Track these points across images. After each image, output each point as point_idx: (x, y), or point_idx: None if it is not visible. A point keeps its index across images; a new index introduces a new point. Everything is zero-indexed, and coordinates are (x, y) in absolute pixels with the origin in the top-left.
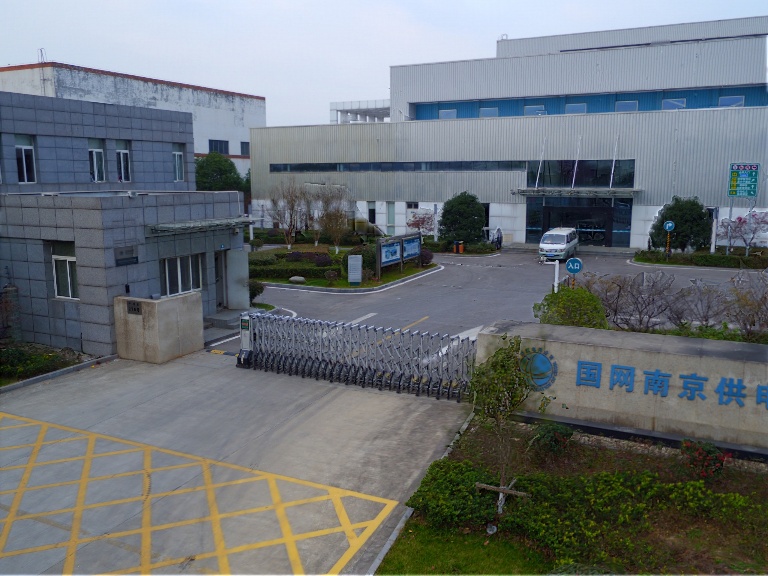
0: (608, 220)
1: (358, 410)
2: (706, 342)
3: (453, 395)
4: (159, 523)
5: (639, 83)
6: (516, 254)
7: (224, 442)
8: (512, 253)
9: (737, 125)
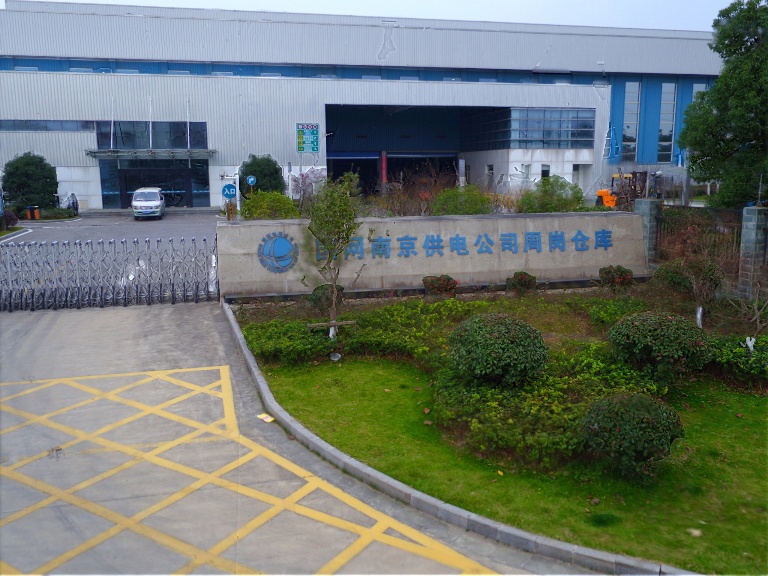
0: (187, 181)
1: (97, 323)
2: (399, 217)
3: (186, 298)
4: None
5: (190, 53)
6: (100, 218)
7: None
8: (95, 217)
9: (290, 93)
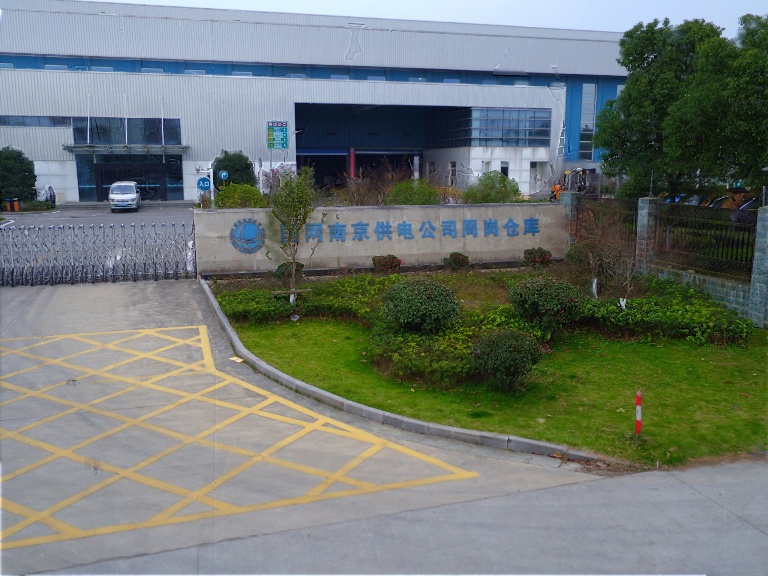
0: (161, 175)
1: (91, 295)
2: None
3: (167, 276)
4: None
5: (163, 52)
6: (77, 210)
7: None
8: (72, 210)
9: (261, 92)
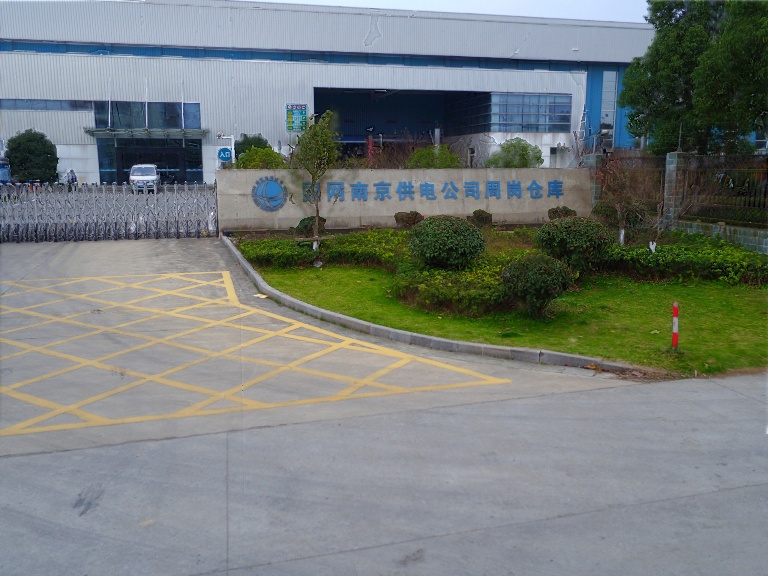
0: (181, 160)
1: (114, 249)
2: None
3: (189, 235)
4: (24, 306)
5: (183, 39)
6: None
7: (3, 273)
8: None
9: (280, 77)
